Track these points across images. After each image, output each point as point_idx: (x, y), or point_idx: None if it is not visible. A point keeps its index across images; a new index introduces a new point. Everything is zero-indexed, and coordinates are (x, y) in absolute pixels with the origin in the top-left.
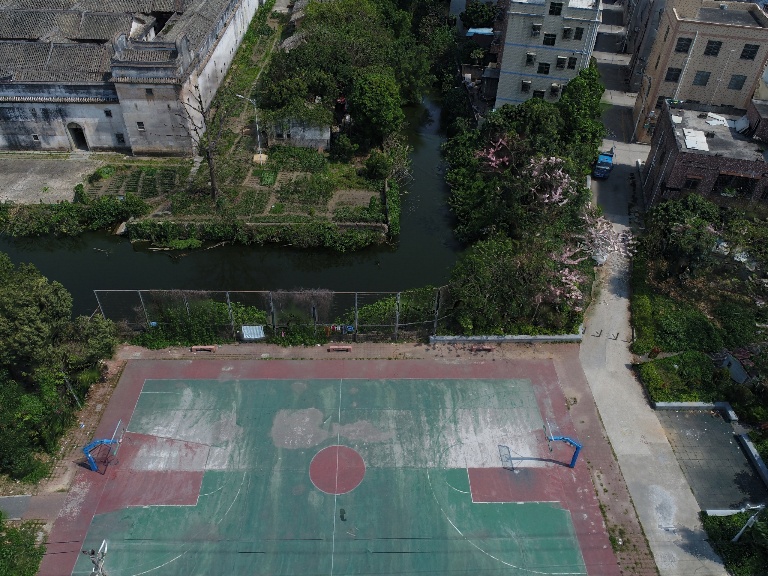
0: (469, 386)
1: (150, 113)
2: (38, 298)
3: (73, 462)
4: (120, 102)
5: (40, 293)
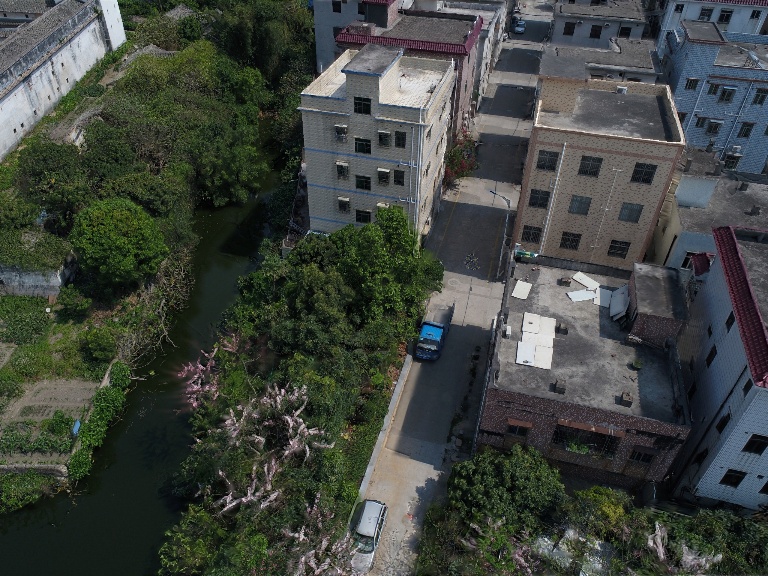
0: None
1: None
2: None
3: None
4: None
5: None
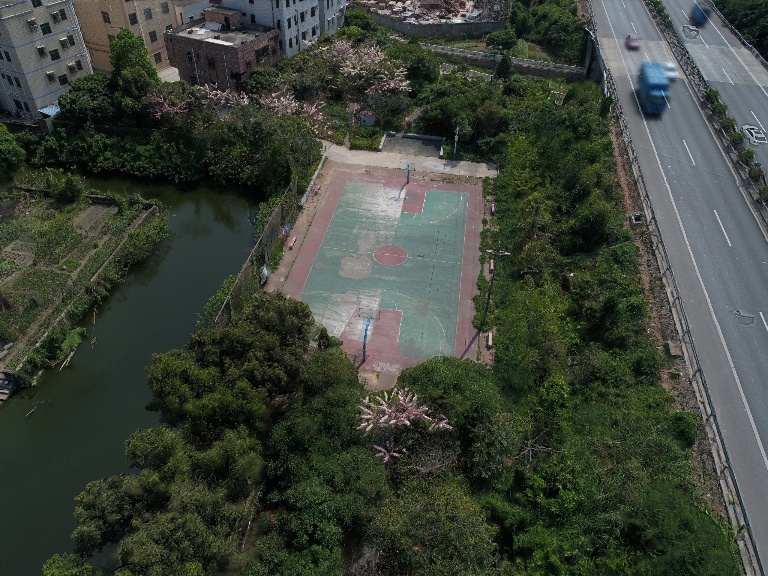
0: (345, 201)
1: None
2: (277, 294)
3: None
4: None
5: (272, 293)
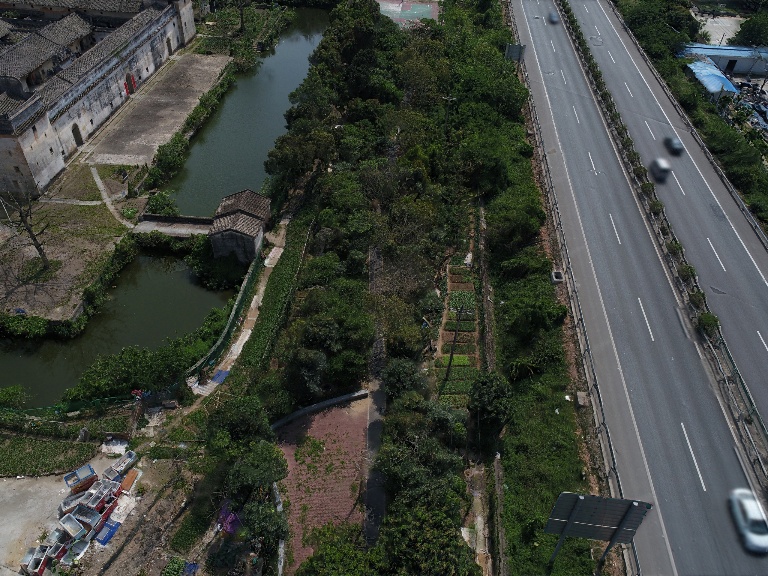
0: None
1: (186, 15)
2: None
3: None
4: None
5: None
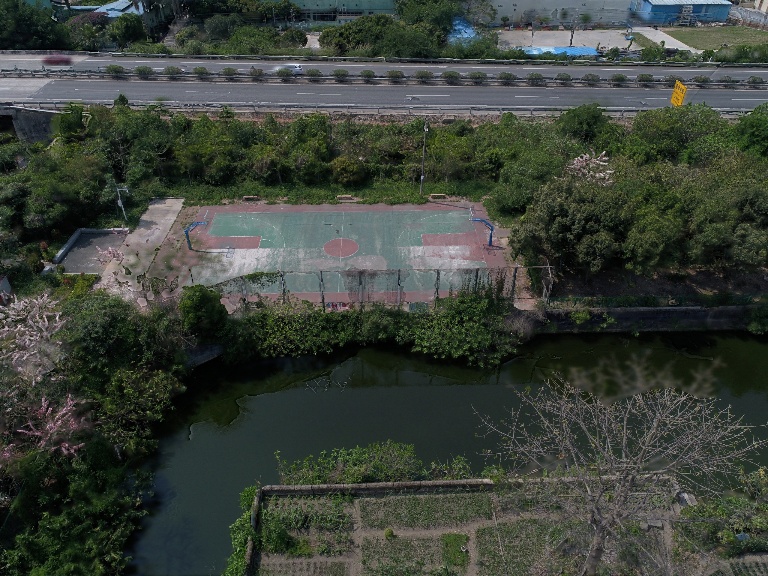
0: None
1: None
2: None
3: (507, 248)
4: None
5: None
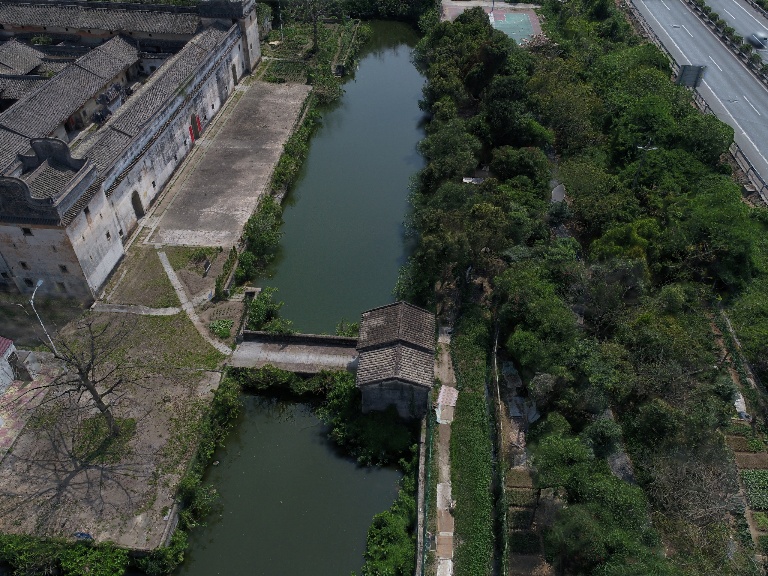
0: None
1: None
2: None
3: None
4: (246, 33)
5: (473, 8)
